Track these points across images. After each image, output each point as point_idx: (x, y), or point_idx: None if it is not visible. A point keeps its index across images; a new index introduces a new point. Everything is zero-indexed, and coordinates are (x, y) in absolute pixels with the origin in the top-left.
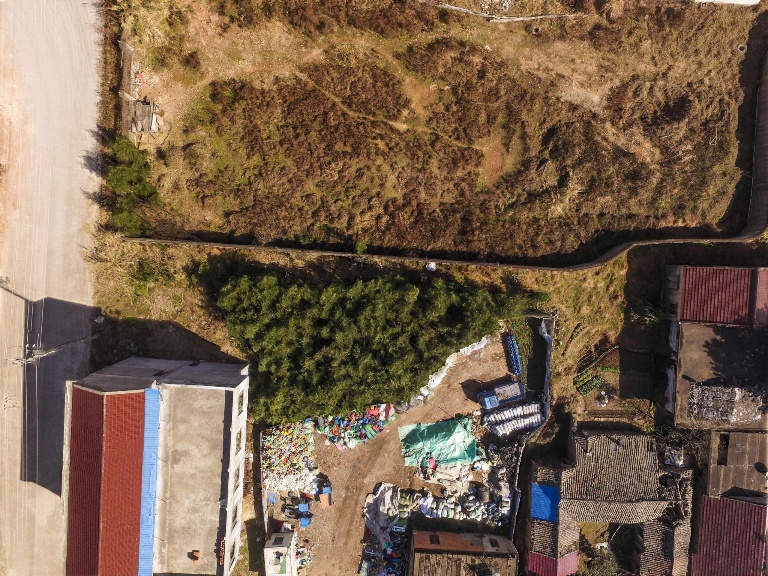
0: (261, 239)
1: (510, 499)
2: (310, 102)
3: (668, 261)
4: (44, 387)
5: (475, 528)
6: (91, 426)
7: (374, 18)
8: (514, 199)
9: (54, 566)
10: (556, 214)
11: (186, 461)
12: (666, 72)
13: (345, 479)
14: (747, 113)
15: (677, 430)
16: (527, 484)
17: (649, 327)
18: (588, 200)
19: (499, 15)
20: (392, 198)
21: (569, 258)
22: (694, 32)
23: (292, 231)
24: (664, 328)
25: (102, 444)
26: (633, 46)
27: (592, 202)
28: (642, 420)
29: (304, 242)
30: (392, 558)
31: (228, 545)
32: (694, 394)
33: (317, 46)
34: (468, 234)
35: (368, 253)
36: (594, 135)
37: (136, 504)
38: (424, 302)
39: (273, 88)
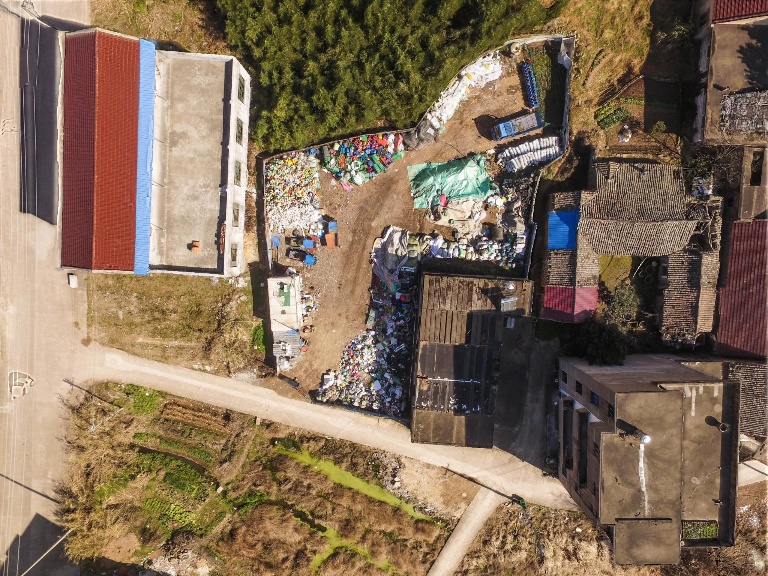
0: None
1: (525, 236)
2: None
3: None
4: (42, 112)
5: (488, 272)
6: (83, 52)
7: None
8: None
9: (55, 304)
10: None
11: (185, 144)
12: None
13: (352, 222)
14: None
15: (706, 151)
16: (543, 223)
17: (677, 50)
18: None
19: None
20: None
21: None
22: None
23: None
24: (693, 52)
25: (95, 79)
26: None
27: None
28: (668, 157)
29: None
30: (401, 303)
31: (229, 234)
32: (726, 104)
33: None
34: None
35: None
36: None
37: (132, 165)
38: (435, 3)
39: None
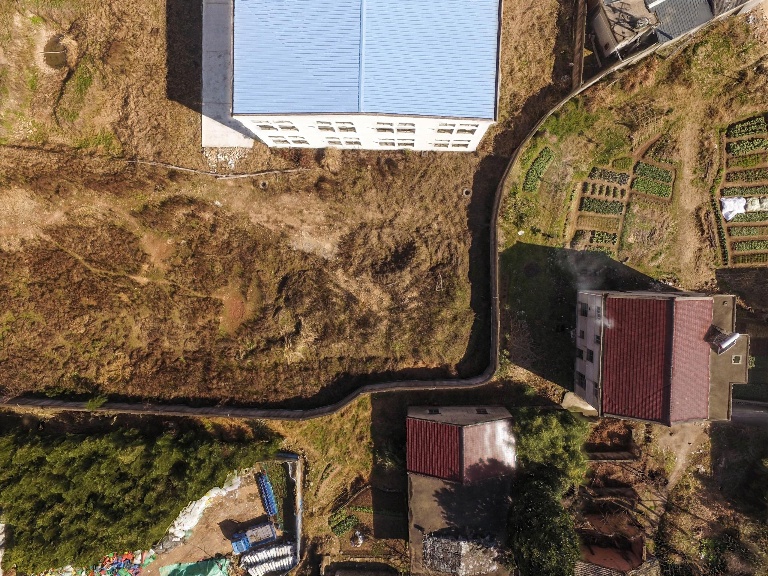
0: (7, 395)
1: None
2: (53, 262)
3: (412, 402)
4: None
5: None
6: None
7: (104, 183)
8: (254, 345)
9: None
10: (297, 358)
11: None
12: (392, 219)
13: None
14: (479, 254)
15: None
16: None
17: None
18: (323, 346)
19: (226, 172)
20: (137, 348)
21: (312, 401)
22: (418, 179)
23: (43, 383)
24: None
25: None
26: (358, 196)
27: (327, 348)
28: (398, 560)
29: (50, 395)
30: None
31: None
32: (426, 544)
33: (58, 209)
34: (208, 382)
35: (116, 402)
36: (325, 283)
37: None
38: None
39: (20, 249)
